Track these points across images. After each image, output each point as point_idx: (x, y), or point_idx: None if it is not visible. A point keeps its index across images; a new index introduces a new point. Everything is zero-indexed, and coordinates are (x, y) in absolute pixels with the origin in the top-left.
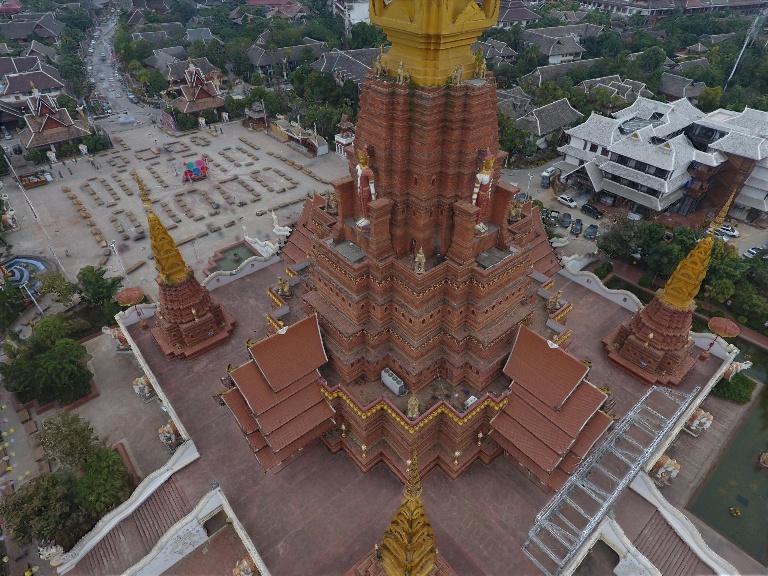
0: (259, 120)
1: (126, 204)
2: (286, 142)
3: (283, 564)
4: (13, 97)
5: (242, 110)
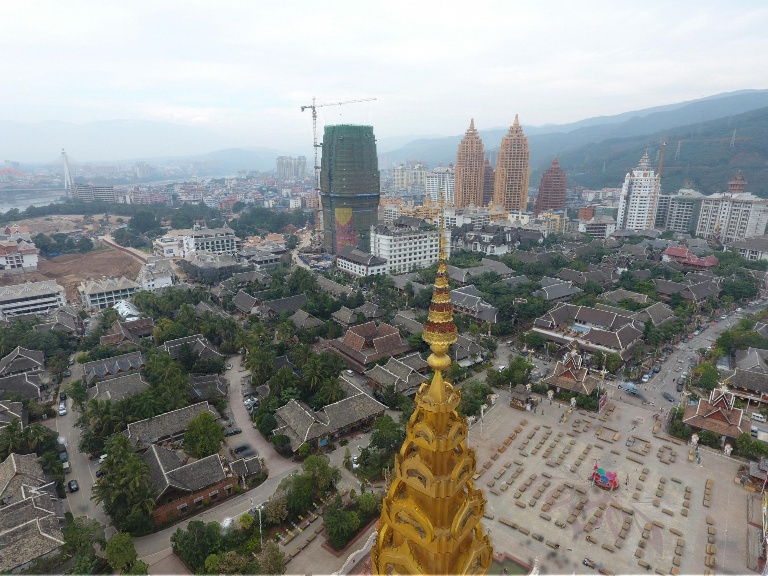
0: (759, 479)
1: (531, 461)
2: (753, 526)
3: None
4: (585, 341)
5: (758, 455)
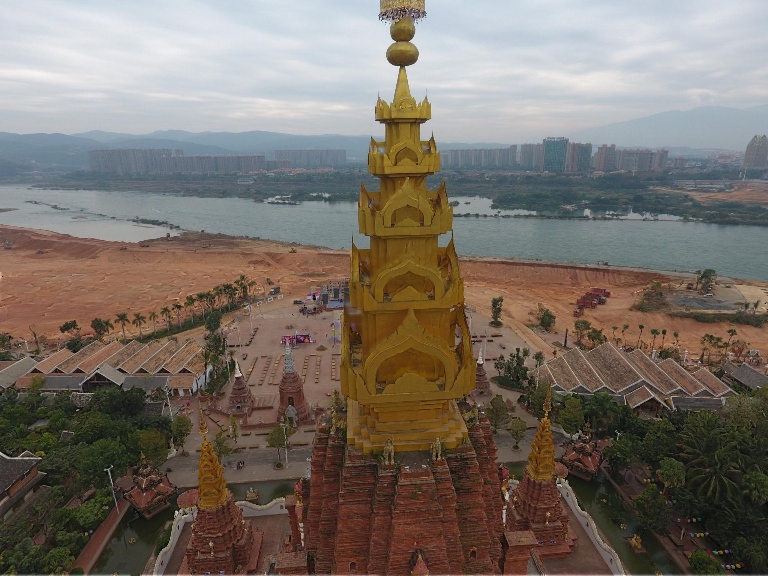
0: None
1: None
2: None
3: None
4: None
5: None
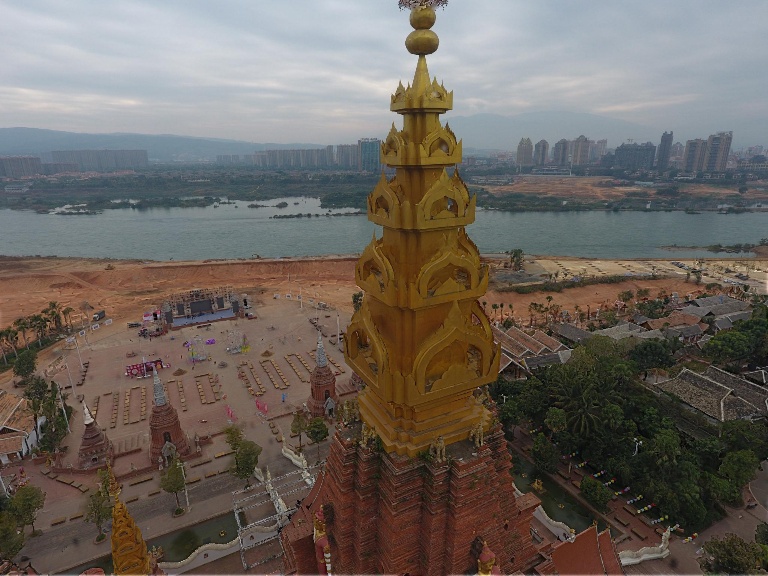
0: None
1: None
2: None
3: (538, 528)
4: None
5: None
